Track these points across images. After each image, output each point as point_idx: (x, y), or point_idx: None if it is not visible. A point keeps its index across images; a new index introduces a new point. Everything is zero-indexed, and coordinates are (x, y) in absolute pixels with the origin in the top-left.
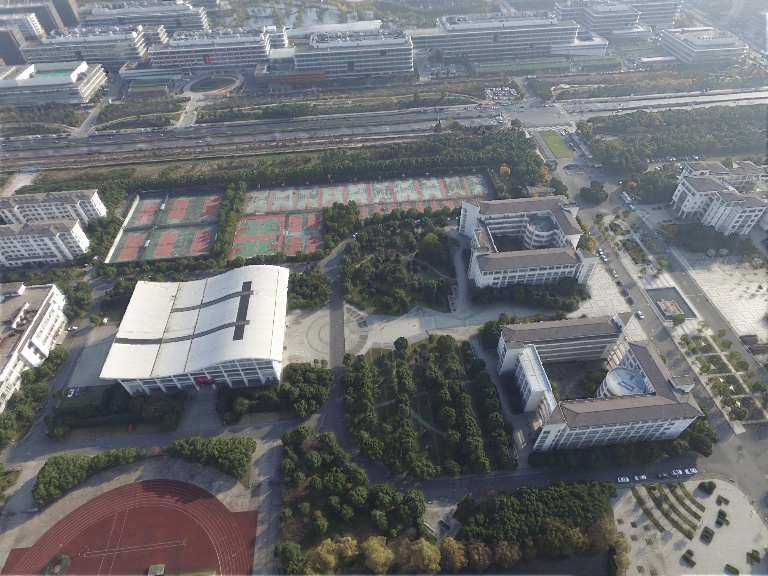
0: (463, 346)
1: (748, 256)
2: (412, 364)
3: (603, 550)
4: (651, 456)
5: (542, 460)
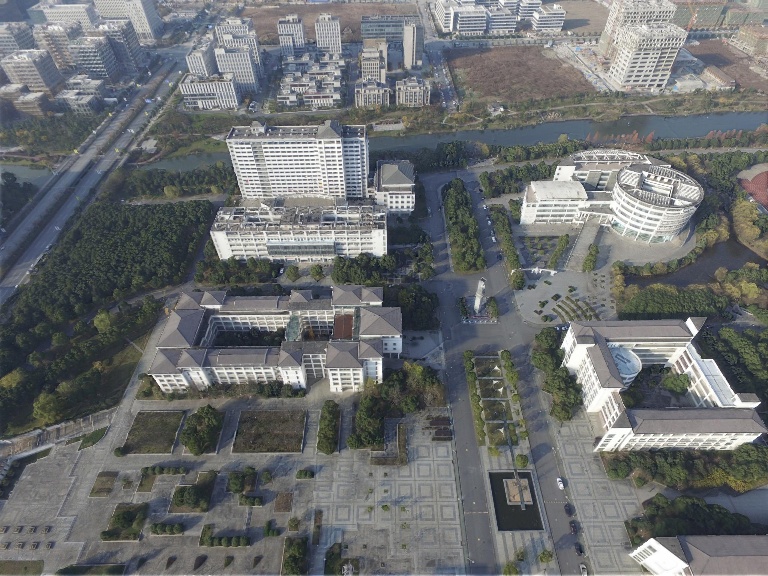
0: None
1: None
2: None
3: None
4: None
5: None
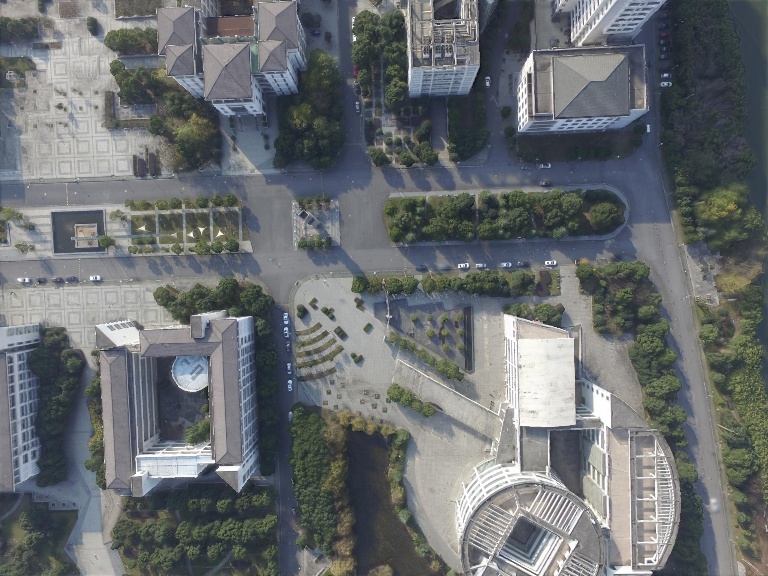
0: (129, 508)
1: (1, 83)
2: (150, 568)
3: (347, 430)
4: (272, 366)
5: (269, 469)
